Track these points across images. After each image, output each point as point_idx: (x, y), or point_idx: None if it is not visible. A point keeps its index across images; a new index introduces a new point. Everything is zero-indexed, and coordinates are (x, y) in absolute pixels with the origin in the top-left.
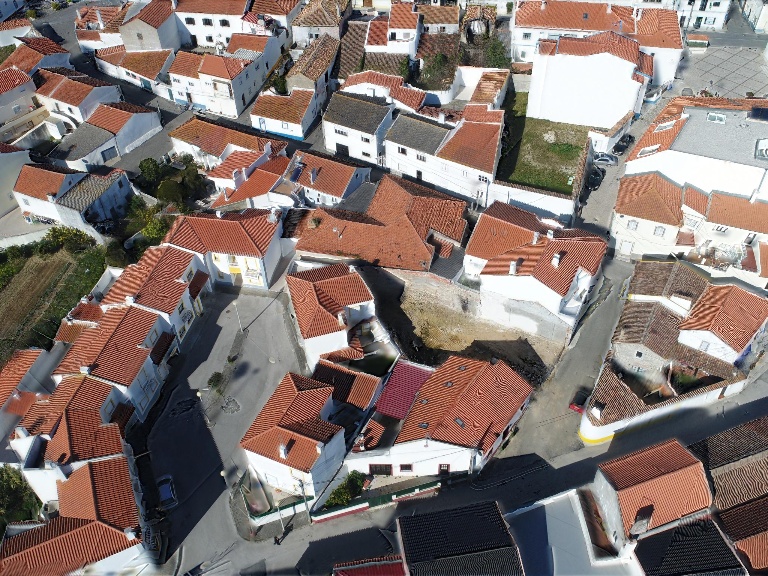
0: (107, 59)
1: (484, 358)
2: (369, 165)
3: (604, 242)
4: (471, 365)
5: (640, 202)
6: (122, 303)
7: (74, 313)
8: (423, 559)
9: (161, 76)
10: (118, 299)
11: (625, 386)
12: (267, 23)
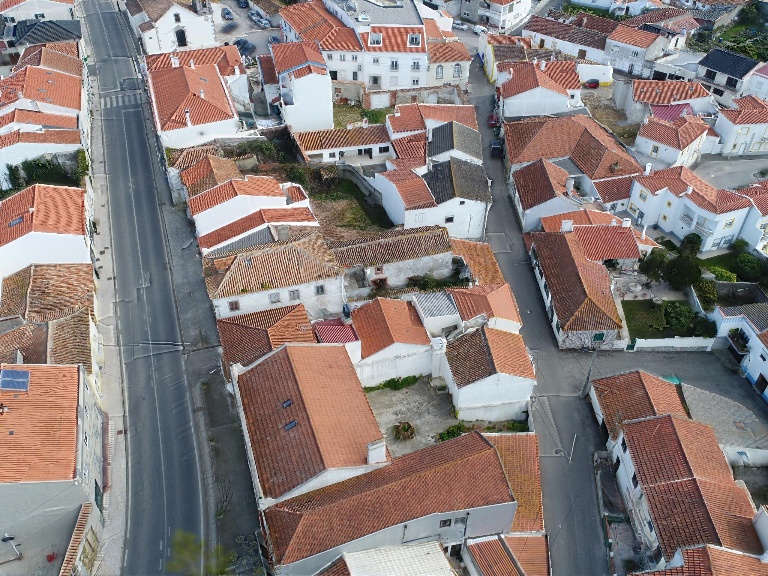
0: (543, 575)
1: (600, 117)
2: None
3: (501, 62)
4: (639, 87)
5: (459, 50)
6: None
7: None
8: (752, 61)
9: (523, 430)
10: None
11: (581, 62)
12: (333, 323)
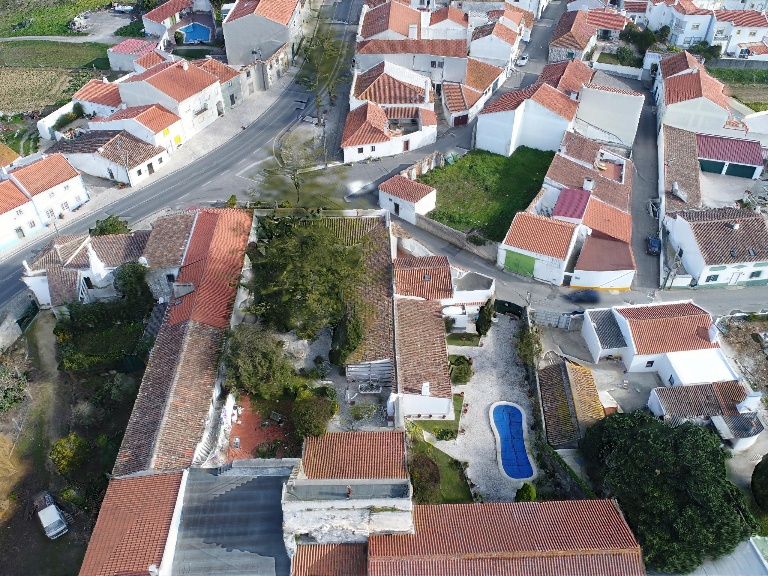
0: (473, 101)
1: None
2: (548, 8)
3: None
4: None
5: None
6: (765, 16)
7: (767, 53)
8: None
9: None
10: (763, 19)
11: None
12: None
